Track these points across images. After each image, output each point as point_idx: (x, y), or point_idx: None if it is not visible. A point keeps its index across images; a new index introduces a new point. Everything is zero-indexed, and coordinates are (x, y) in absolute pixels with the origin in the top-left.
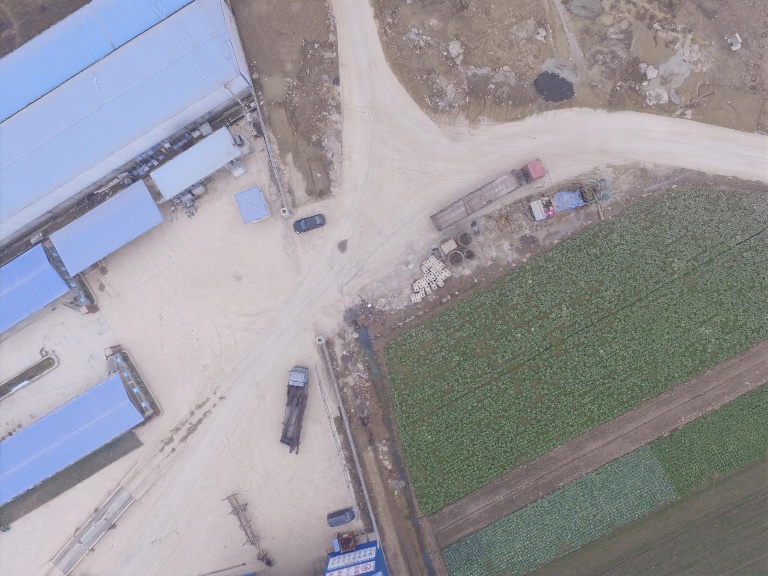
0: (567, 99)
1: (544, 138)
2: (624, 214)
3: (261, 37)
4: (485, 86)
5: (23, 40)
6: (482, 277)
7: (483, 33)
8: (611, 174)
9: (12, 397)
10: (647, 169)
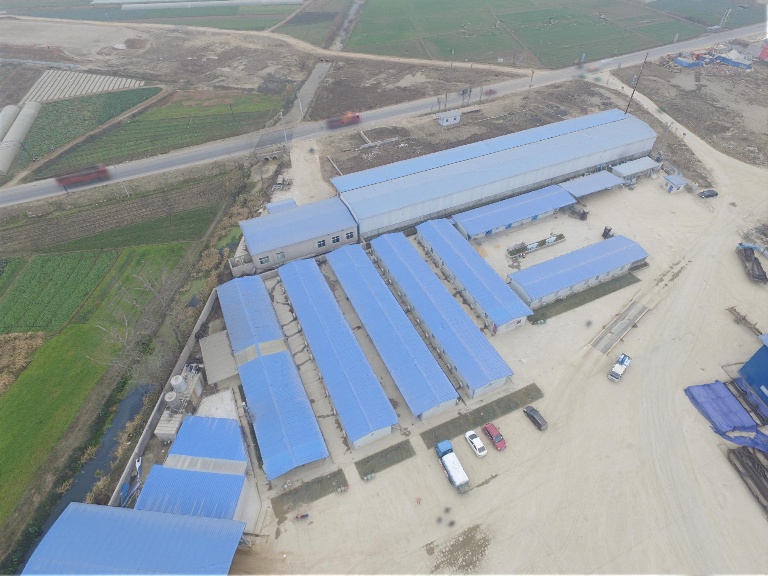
0: None
1: None
2: None
3: None
4: None
5: None
6: None
7: (764, 143)
8: None
9: (535, 253)
10: None
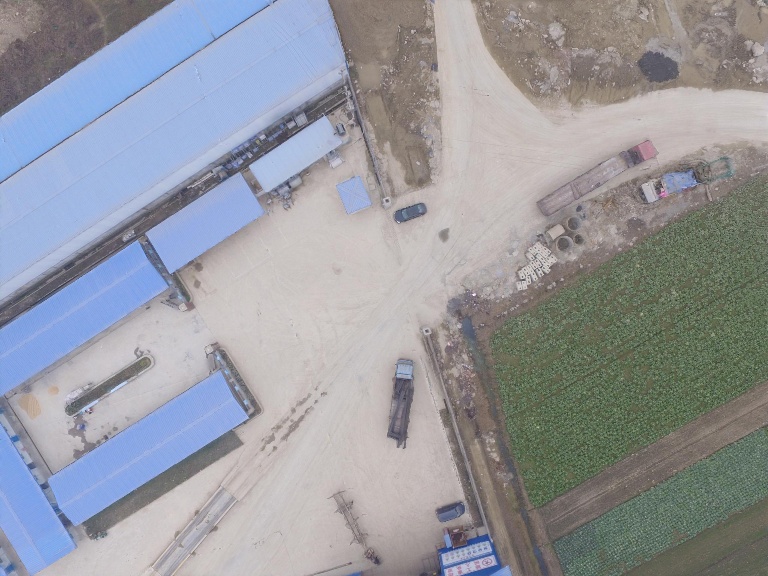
0: (672, 79)
1: (649, 119)
2: (732, 194)
3: (356, 24)
4: (589, 68)
5: (111, 34)
6: (588, 262)
7: (585, 14)
8: (719, 154)
9: (107, 399)
10: (755, 148)
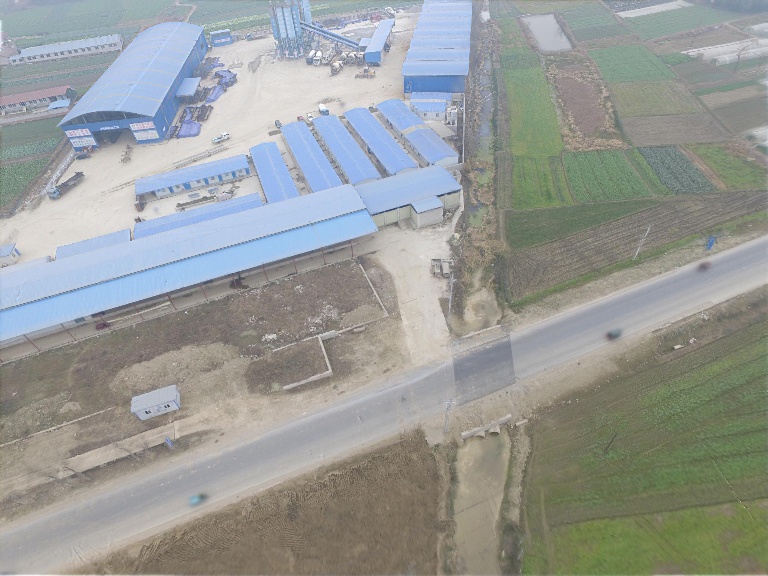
0: None
1: None
2: None
3: None
4: None
5: (73, 359)
6: None
7: None
8: None
9: None
10: None
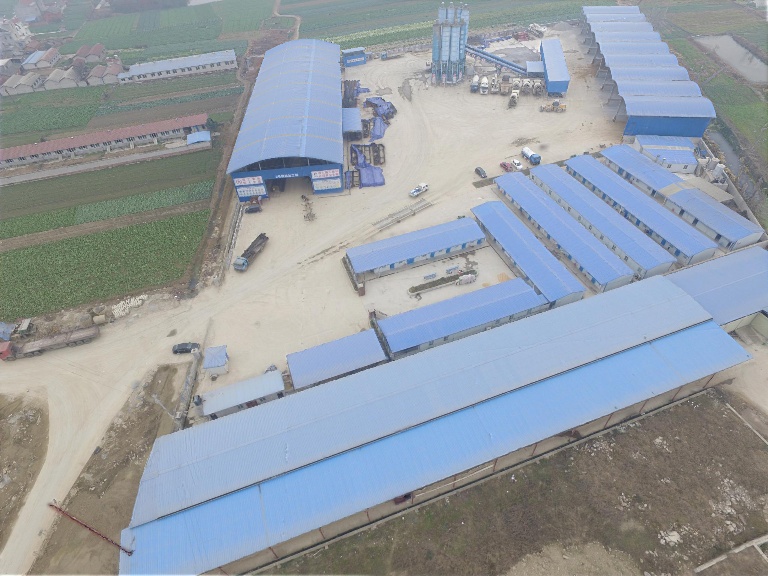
0: None
1: None
2: None
3: None
4: None
5: (383, 560)
6: None
7: None
8: None
9: None
10: None
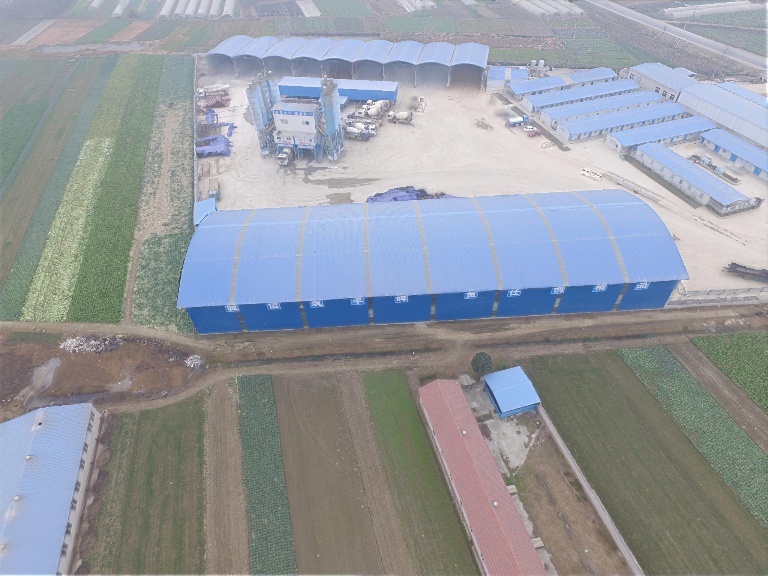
0: None
1: None
2: None
3: None
4: None
5: None
6: None
7: None
8: None
9: (704, 168)
10: None
